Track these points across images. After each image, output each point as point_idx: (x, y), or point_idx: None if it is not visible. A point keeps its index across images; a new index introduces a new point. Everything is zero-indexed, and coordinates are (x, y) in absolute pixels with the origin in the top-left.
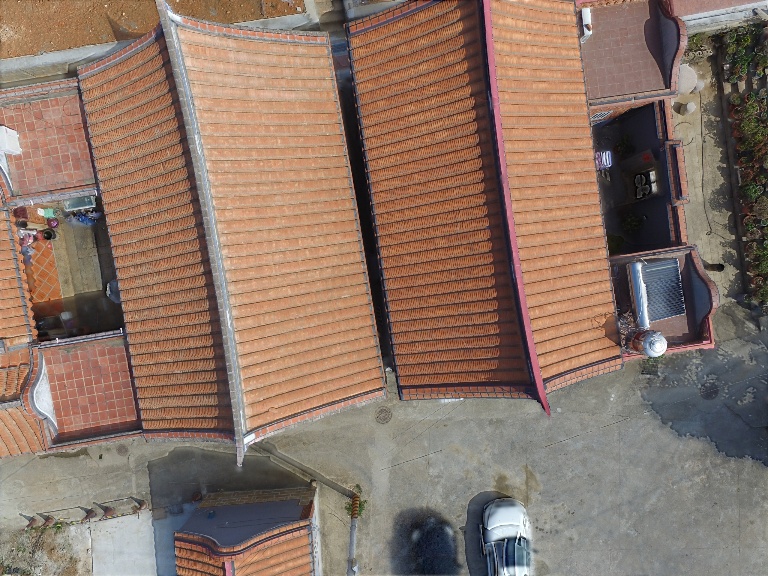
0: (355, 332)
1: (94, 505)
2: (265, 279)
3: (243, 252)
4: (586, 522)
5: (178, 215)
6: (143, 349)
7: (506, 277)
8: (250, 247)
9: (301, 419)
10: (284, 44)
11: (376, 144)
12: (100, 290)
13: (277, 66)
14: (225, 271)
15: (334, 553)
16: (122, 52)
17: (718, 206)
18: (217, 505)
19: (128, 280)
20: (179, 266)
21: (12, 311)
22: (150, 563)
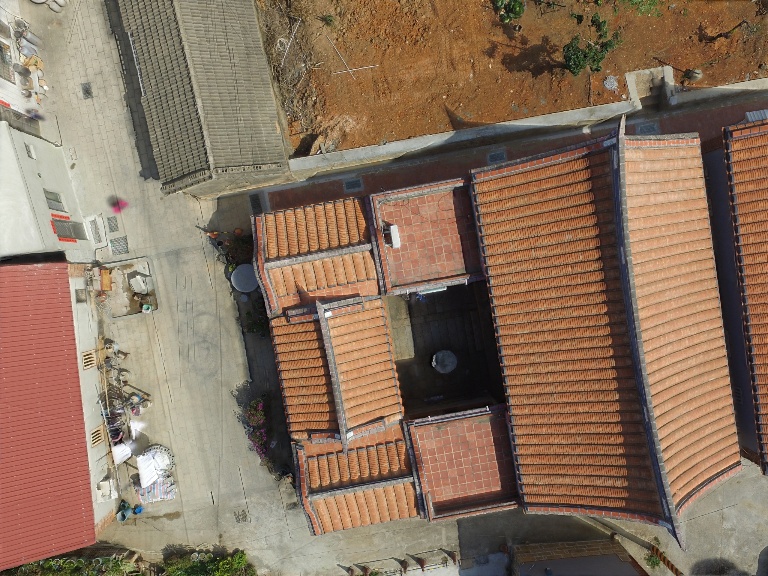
0: (720, 412)
1: (407, 556)
2: (663, 370)
3: (649, 347)
4: None
5: (586, 313)
6: (530, 430)
7: None
8: (654, 342)
9: None
10: (670, 148)
11: (753, 240)
12: (412, 358)
13: (666, 170)
14: None
15: None
16: (536, 163)
17: None
18: (538, 559)
19: (516, 367)
20: (581, 358)
21: (387, 391)
22: None
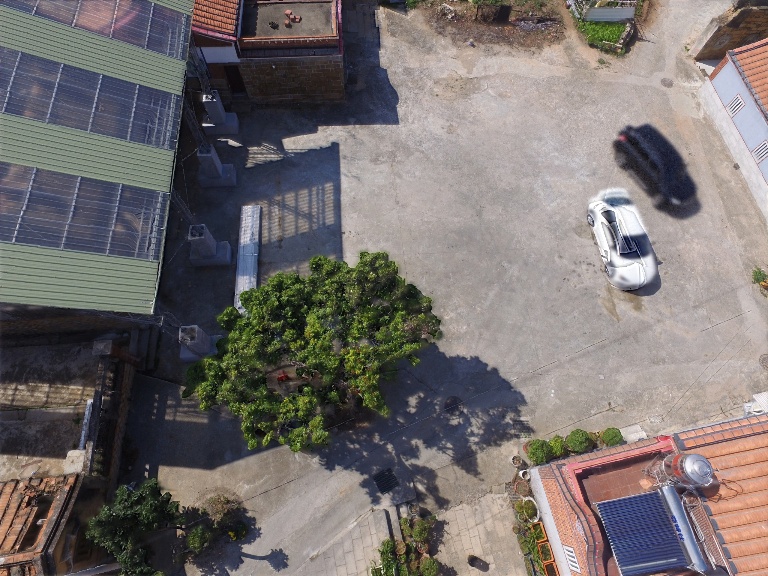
0: None
1: None
2: None
3: None
4: (551, 272)
5: None
6: None
7: None
8: None
9: None
10: None
11: None
12: None
13: None
14: None
15: (763, 239)
16: None
17: None
18: None
19: None
20: None
21: None
22: None
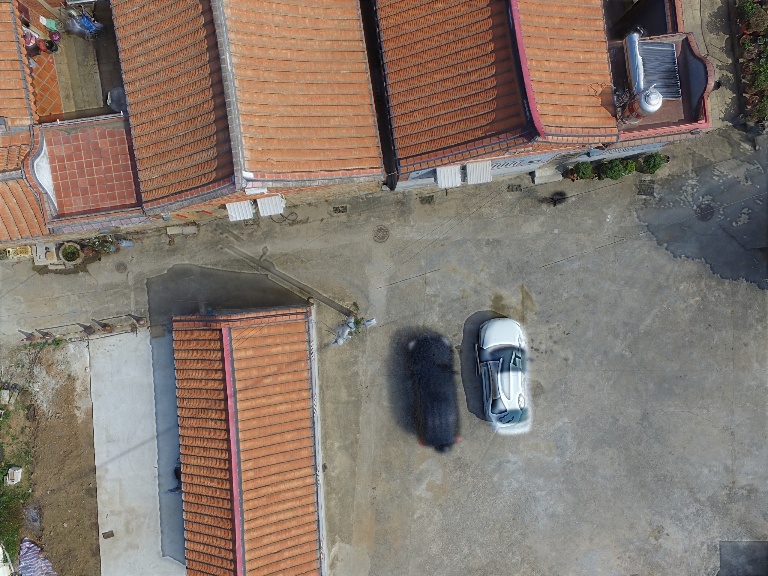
0: (353, 108)
1: (93, 322)
2: (265, 37)
3: (243, 5)
4: (581, 342)
5: None
6: (143, 118)
7: (503, 27)
8: (250, 2)
9: (299, 177)
10: None
11: None
12: (101, 107)
13: None
14: (225, 18)
15: (330, 370)
16: None
17: (715, 29)
18: None
19: (129, 49)
20: (180, 25)
21: (13, 92)
22: (148, 382)
